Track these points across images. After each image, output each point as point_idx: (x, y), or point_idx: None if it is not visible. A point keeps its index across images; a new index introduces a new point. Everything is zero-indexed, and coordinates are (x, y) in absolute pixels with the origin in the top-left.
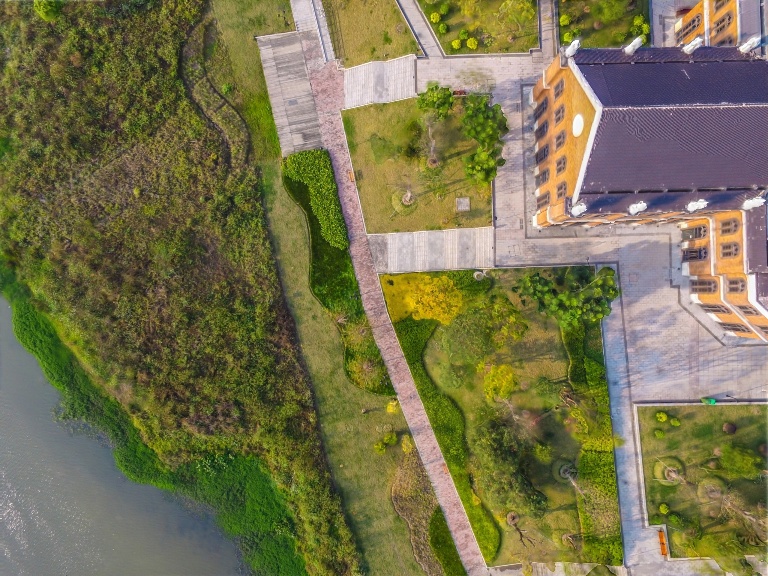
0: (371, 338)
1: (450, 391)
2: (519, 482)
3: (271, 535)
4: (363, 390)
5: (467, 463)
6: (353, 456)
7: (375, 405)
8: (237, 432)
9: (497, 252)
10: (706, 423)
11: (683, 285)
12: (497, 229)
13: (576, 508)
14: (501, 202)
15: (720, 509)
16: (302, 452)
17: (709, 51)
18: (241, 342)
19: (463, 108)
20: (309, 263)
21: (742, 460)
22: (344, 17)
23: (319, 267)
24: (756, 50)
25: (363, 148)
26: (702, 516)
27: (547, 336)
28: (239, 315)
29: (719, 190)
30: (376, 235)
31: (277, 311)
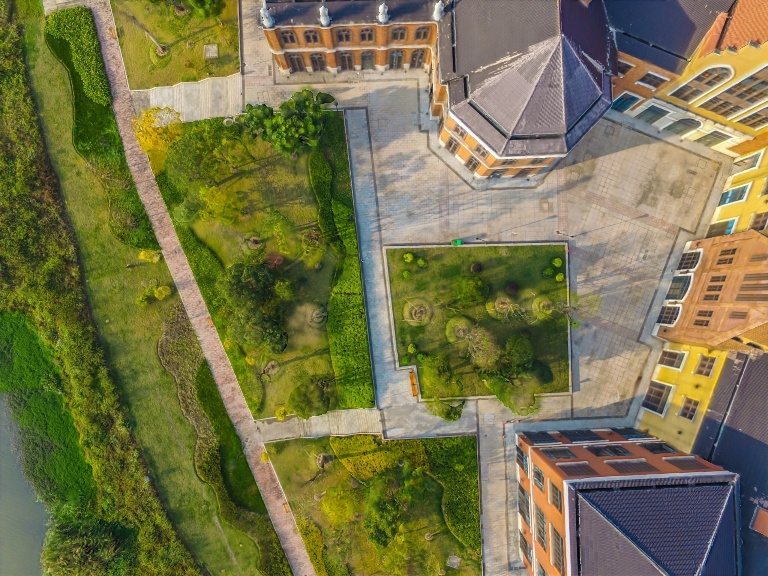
0: (135, 193)
1: (210, 242)
2: (256, 317)
3: (39, 392)
4: (128, 245)
5: (229, 314)
6: (119, 311)
7: (140, 260)
8: (2, 288)
9: (246, 98)
10: (454, 264)
11: (432, 130)
12: (246, 75)
13: (329, 352)
14: (249, 49)
15: (467, 348)
16: (64, 305)
17: None
18: (3, 197)
19: None
20: (72, 120)
21: (466, 285)
22: None
23: (82, 124)
24: None
25: (123, 4)
26: (451, 356)
27: (297, 181)
28: (0, 170)
29: None
30: (139, 91)
31: (38, 166)
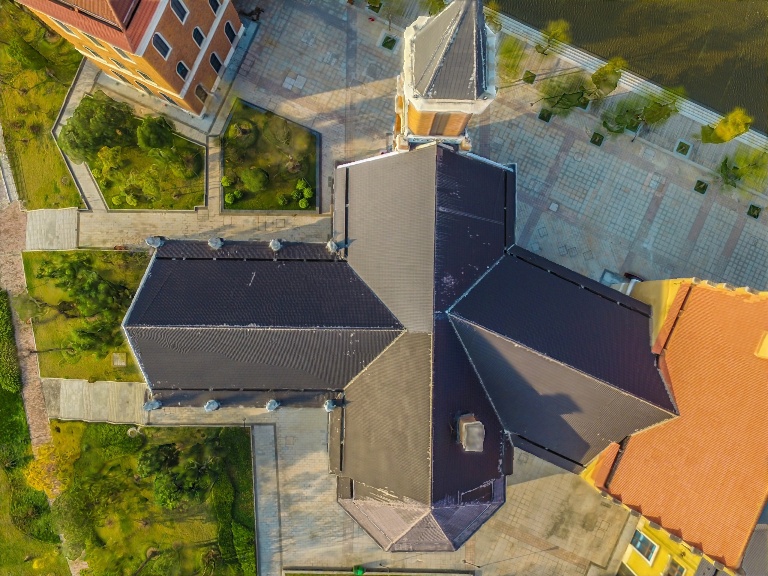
0: None
1: None
2: None
3: None
4: (28, 536)
5: None
6: None
7: (40, 552)
8: None
9: None
10: None
11: None
12: None
13: None
14: None
15: None
16: None
17: (298, 247)
18: None
19: (123, 263)
20: None
21: None
22: (25, 161)
23: None
24: (341, 250)
25: (39, 291)
26: None
27: None
28: None
29: (296, 390)
30: (50, 379)
31: None
